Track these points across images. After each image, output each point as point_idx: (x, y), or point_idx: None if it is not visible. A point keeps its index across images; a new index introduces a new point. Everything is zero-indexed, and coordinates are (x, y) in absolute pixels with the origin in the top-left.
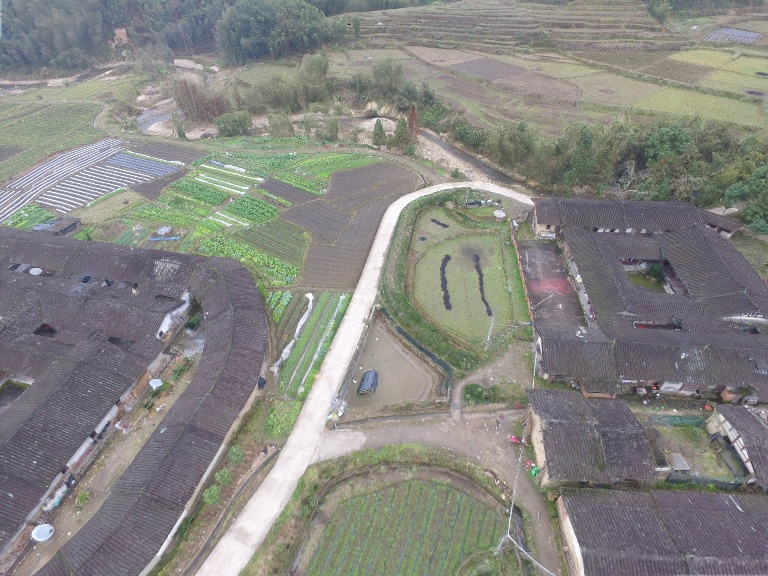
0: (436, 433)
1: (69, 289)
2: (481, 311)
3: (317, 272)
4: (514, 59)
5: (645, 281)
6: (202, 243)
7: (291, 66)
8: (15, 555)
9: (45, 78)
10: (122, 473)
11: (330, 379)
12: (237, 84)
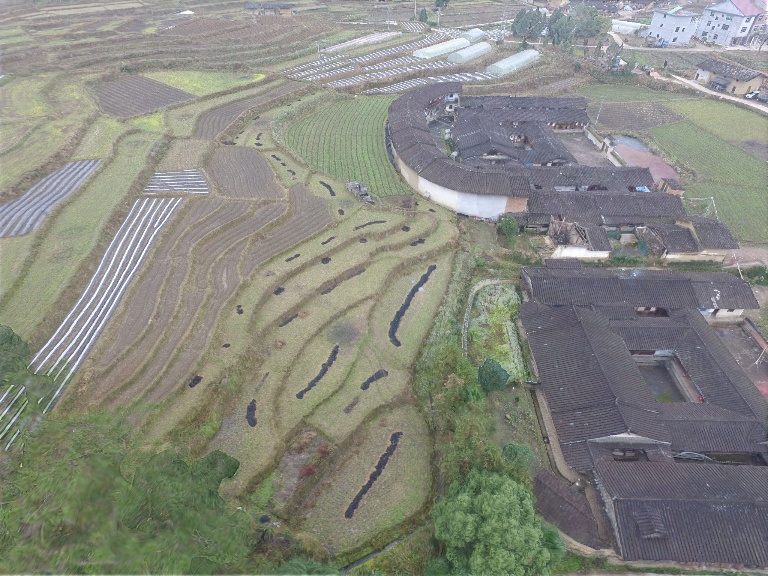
0: None
1: None
2: None
3: None
4: None
5: None
6: None
7: None
8: None
9: None
10: None
11: None
12: None
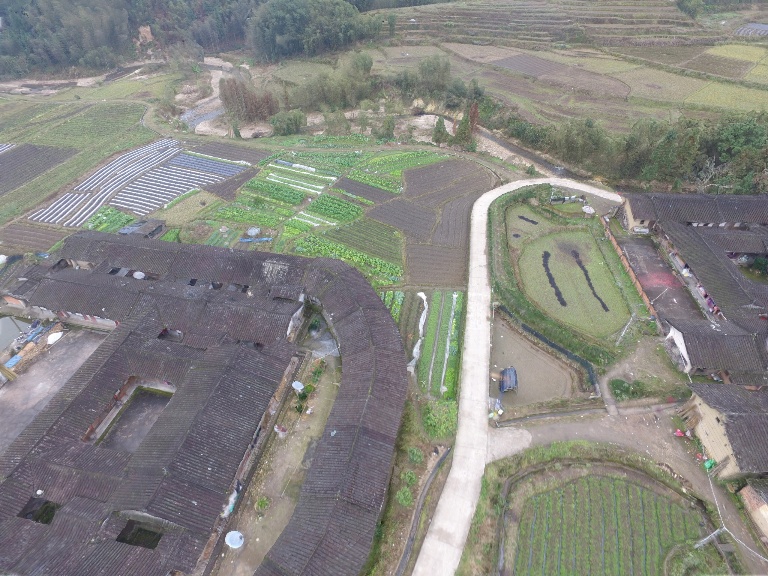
0: (599, 429)
1: (182, 293)
2: (597, 307)
3: (421, 271)
4: (553, 55)
5: (749, 274)
6: (296, 244)
7: (326, 63)
8: (204, 563)
9: (73, 77)
10: (292, 477)
11: (476, 378)
12: (275, 82)
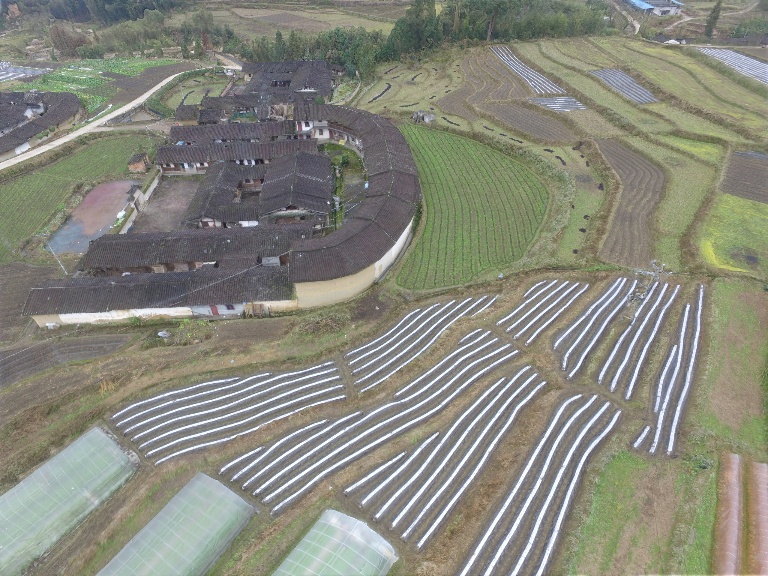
0: None
1: None
2: None
3: (118, 99)
4: (302, 13)
5: None
6: None
7: None
8: None
9: None
10: None
11: (105, 118)
12: None
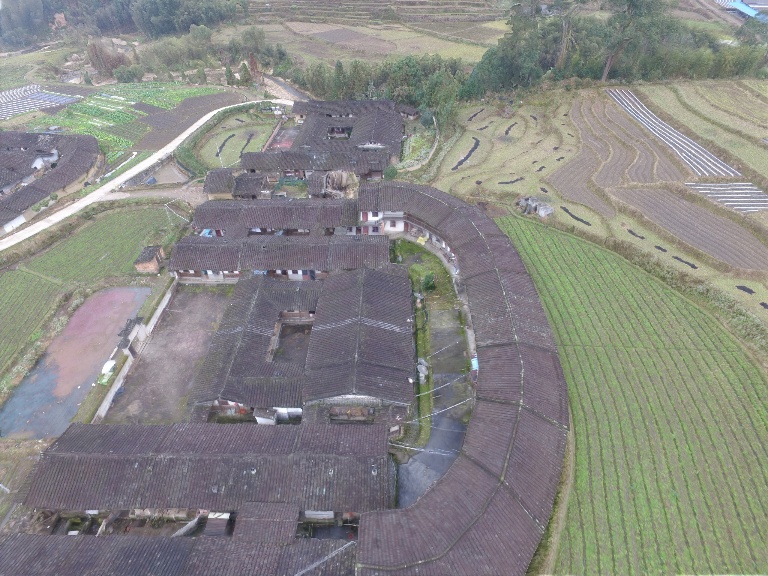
0: (169, 193)
1: None
2: (236, 156)
3: (146, 144)
4: (364, 29)
5: None
6: (77, 133)
7: None
8: None
9: None
10: None
11: (123, 178)
12: None
